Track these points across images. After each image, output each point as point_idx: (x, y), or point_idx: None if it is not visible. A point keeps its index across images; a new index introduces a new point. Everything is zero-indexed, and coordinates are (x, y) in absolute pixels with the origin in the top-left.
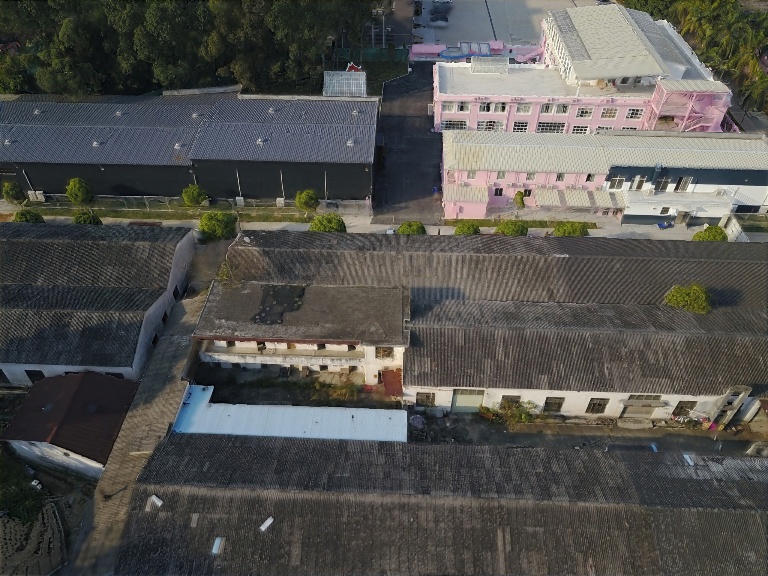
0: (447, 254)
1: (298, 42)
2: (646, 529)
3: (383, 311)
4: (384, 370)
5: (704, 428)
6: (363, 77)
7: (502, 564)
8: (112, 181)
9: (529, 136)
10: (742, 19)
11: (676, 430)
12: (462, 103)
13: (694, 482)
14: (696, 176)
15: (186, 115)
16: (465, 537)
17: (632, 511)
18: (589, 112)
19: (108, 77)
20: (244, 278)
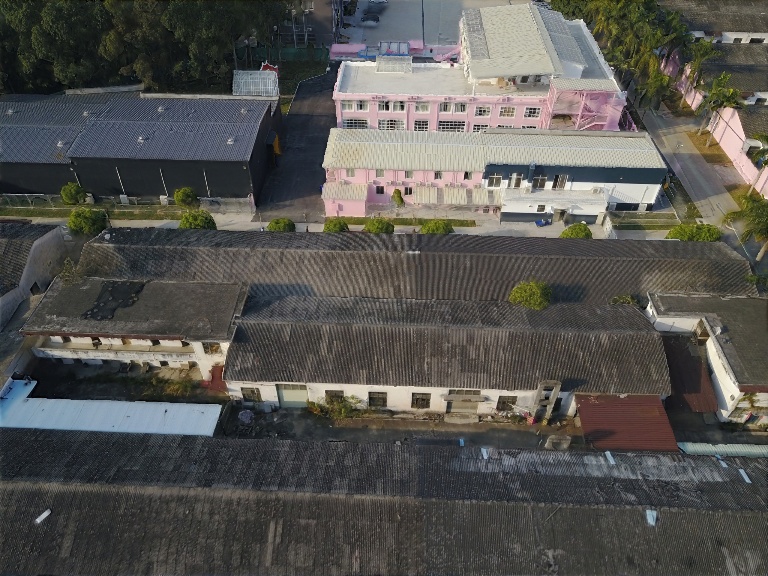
0: (300, 251)
1: (197, 41)
2: (417, 521)
3: (216, 307)
4: (215, 365)
5: (528, 423)
6: (272, 76)
7: (269, 556)
8: None
9: (414, 134)
10: (643, 18)
11: (501, 425)
12: (361, 102)
13: (480, 475)
14: (571, 174)
15: (77, 113)
16: (237, 529)
17: (406, 503)
18: (487, 111)
19: (17, 76)
20: (95, 275)
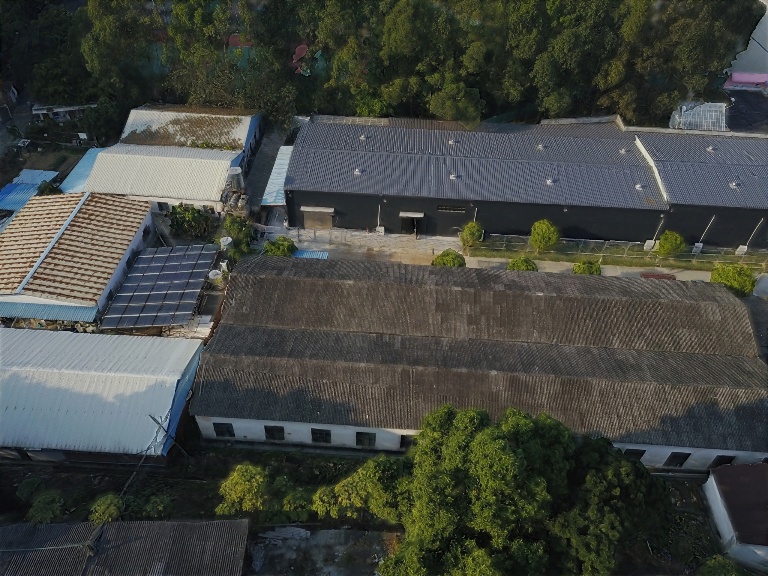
0: None
1: (700, 73)
2: None
3: None
4: None
5: None
6: (724, 109)
7: None
8: (567, 222)
9: None
10: None
11: None
12: None
13: None
14: None
15: (613, 150)
16: None
17: None
18: None
19: None
20: None
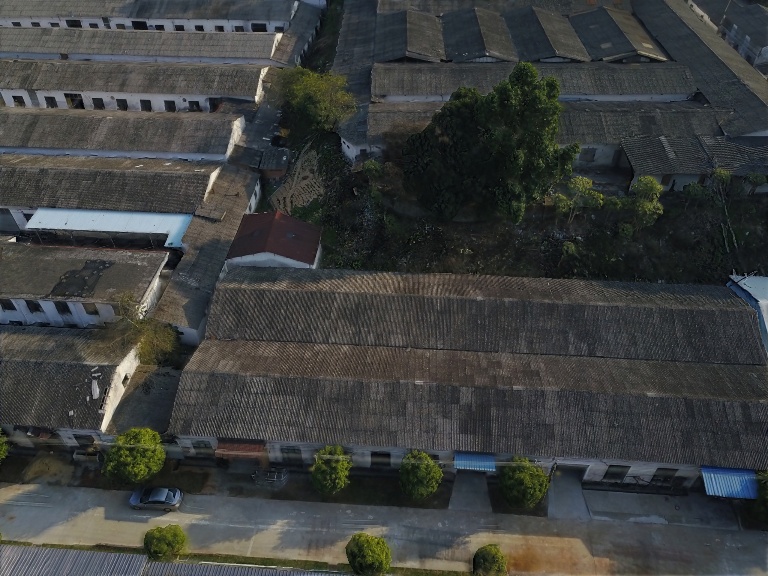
0: None
1: None
2: None
3: None
4: None
5: None
6: None
7: None
8: None
9: None
10: None
11: None
12: None
13: None
14: None
15: None
16: None
17: None
18: None
19: None
20: None
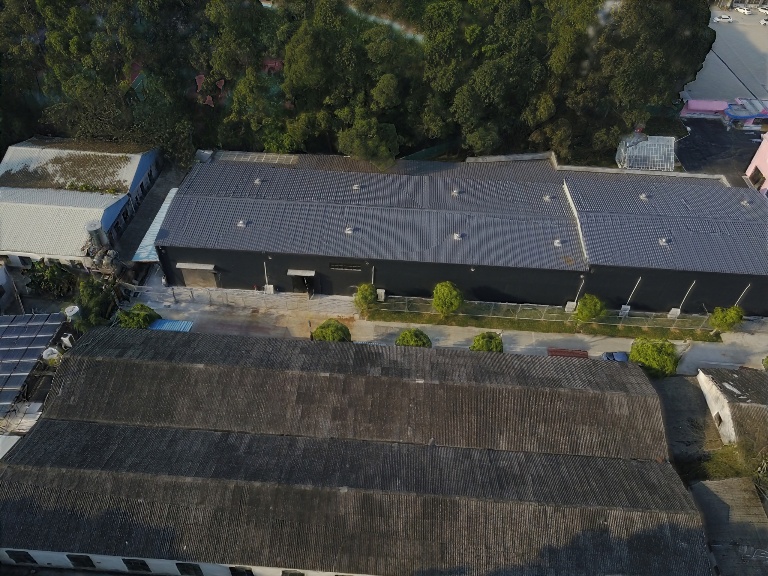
0: None
1: (640, 108)
2: None
3: None
4: None
5: None
6: (673, 143)
7: None
8: (476, 282)
9: None
10: None
11: None
12: None
13: None
14: None
15: (536, 197)
16: None
17: None
18: None
19: None
20: None
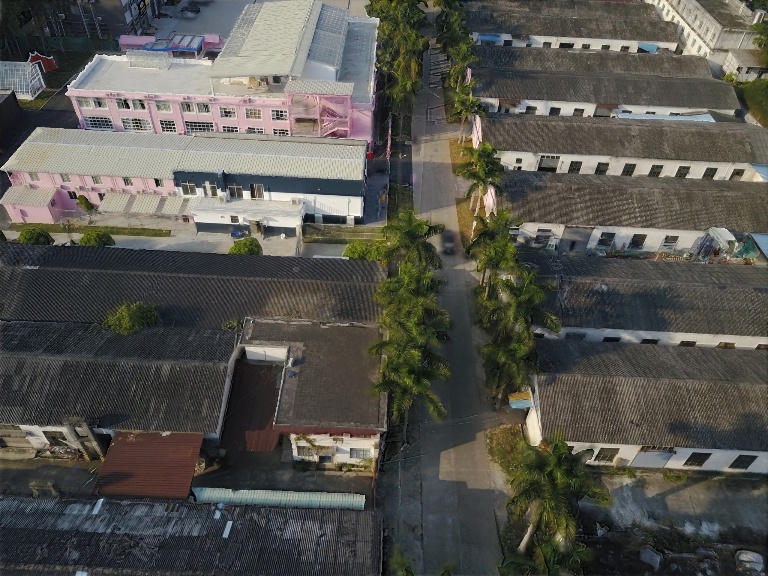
0: None
1: None
2: None
3: None
4: None
5: (86, 459)
6: (28, 68)
7: None
8: None
9: (122, 136)
10: (408, 19)
11: (57, 461)
12: (97, 99)
13: None
14: (266, 183)
15: None
16: None
17: None
18: (232, 112)
19: None
20: None
